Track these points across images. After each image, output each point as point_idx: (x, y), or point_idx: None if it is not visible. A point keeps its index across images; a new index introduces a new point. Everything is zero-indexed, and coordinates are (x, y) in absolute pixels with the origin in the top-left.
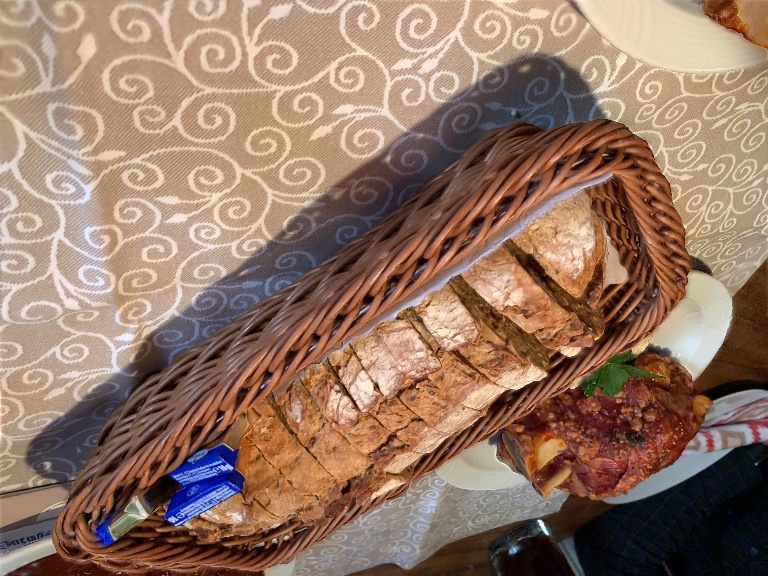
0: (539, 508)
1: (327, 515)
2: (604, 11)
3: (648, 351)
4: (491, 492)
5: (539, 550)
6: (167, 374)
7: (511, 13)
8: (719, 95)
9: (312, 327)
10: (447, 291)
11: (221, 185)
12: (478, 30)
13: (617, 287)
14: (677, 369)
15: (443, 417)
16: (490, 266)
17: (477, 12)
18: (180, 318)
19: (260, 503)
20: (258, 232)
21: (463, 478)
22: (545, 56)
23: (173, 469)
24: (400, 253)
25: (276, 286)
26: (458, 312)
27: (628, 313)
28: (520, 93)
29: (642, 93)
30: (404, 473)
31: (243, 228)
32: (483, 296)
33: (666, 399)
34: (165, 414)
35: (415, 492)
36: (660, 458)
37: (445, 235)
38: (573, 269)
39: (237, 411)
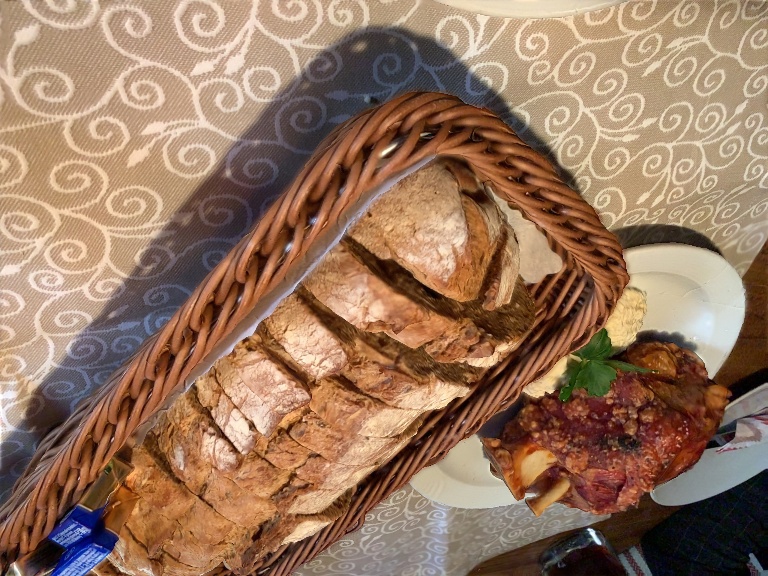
0: (583, 517)
1: (242, 564)
2: None
3: (648, 339)
4: (515, 505)
5: (591, 562)
6: (62, 427)
7: None
8: (635, 35)
9: (139, 373)
10: (302, 313)
11: (40, 230)
12: (280, 14)
13: (555, 277)
14: (685, 356)
15: (343, 450)
16: (340, 279)
17: None
18: (61, 369)
19: (171, 555)
20: (108, 272)
21: (460, 497)
22: (381, 29)
23: (49, 532)
24: (209, 281)
25: (157, 324)
26: (319, 335)
27: (570, 306)
28: (367, 76)
29: (524, 50)
30: (330, 511)
31: (87, 270)
32: (339, 314)
33: (670, 394)
34: (37, 474)
35: (417, 514)
36: (663, 464)
37: (248, 255)
38: (442, 270)
39: (92, 468)
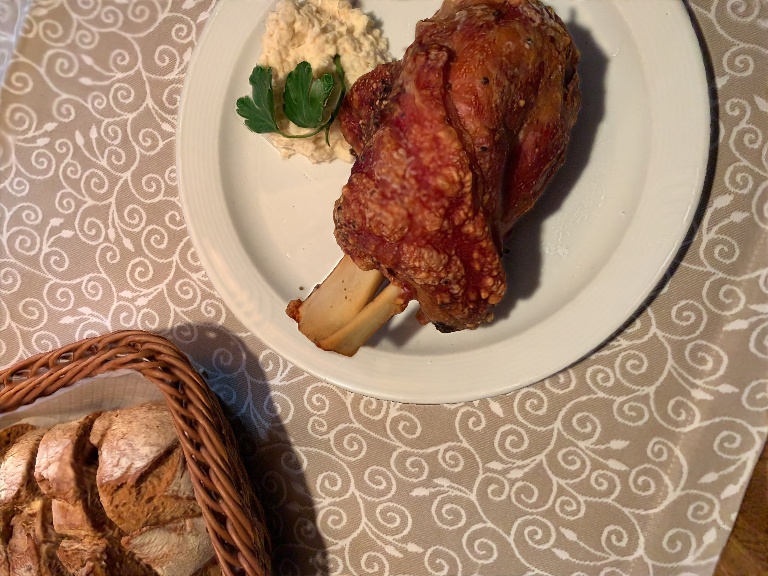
0: None
1: None
2: (225, 285)
3: None
4: None
5: None
6: None
7: (202, 287)
8: (402, 448)
9: None
10: (29, 449)
11: None
12: (178, 290)
13: None
14: None
15: None
16: (59, 437)
17: (179, 277)
18: None
19: None
20: None
21: None
22: (229, 332)
23: None
24: None
25: None
26: (19, 469)
27: None
28: (209, 355)
29: (310, 401)
30: None
31: None
32: (37, 459)
33: None
34: None
35: None
36: None
37: (16, 366)
38: (109, 474)
39: None
